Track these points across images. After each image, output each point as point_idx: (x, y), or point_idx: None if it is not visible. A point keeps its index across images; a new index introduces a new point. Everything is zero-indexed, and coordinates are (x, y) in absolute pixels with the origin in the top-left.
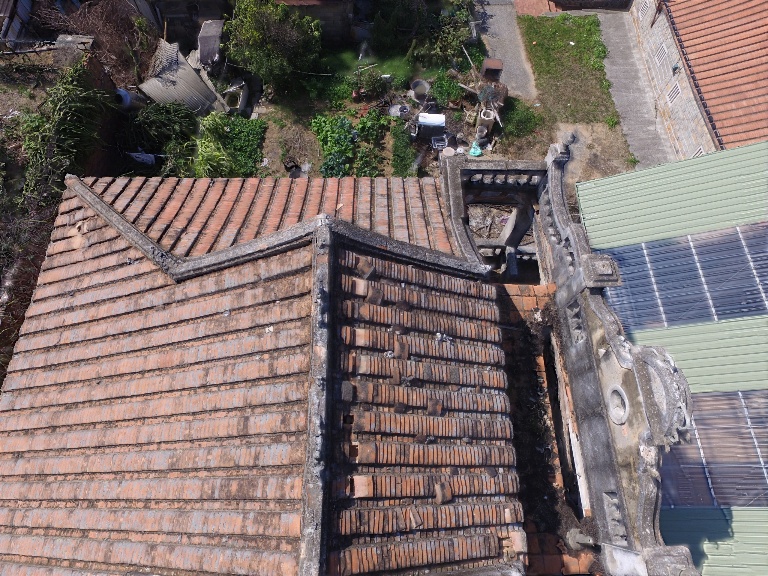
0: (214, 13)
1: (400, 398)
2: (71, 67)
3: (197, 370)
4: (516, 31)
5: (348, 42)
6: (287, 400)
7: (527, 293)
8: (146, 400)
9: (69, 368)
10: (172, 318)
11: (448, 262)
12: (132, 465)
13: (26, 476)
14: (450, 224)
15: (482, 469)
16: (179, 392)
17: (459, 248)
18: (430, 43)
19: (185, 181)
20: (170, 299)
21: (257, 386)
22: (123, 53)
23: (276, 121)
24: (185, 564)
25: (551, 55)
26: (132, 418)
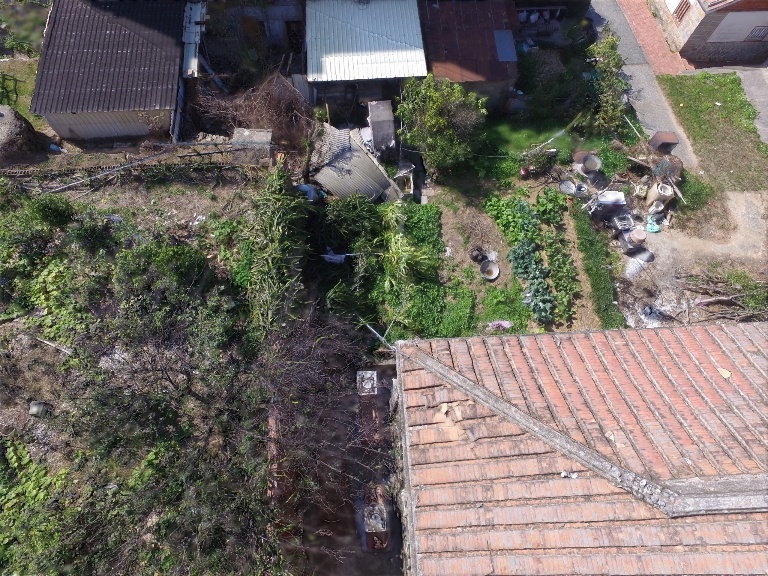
0: (375, 92)
1: None
2: (252, 164)
3: None
4: (659, 92)
5: (500, 113)
6: None
7: None
8: None
9: None
10: (690, 569)
11: None
12: None
13: None
14: None
15: None
16: None
17: None
18: None
19: (529, 342)
20: (673, 541)
21: None
22: (282, 138)
23: (448, 204)
24: None
25: (701, 117)
26: None
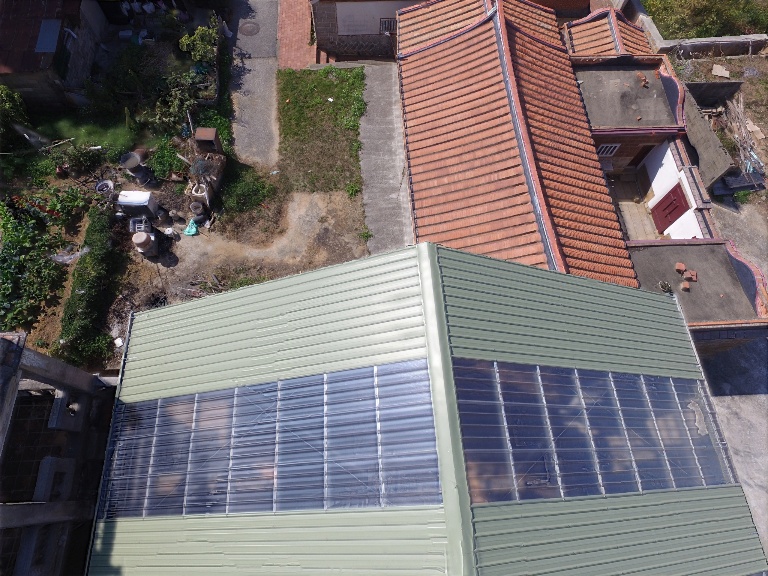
0: None
1: None
2: None
3: None
4: (272, 87)
5: (71, 108)
6: None
7: None
8: None
9: None
10: None
11: None
12: None
13: None
14: None
15: None
16: None
17: None
18: None
19: None
20: None
21: None
22: None
23: None
24: None
25: (304, 114)
26: None
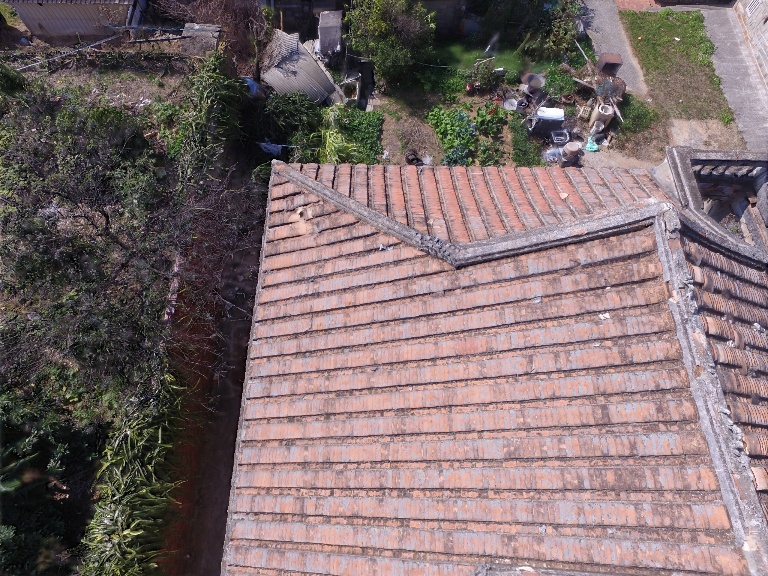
0: (329, 4)
1: (754, 389)
2: (199, 56)
3: (514, 357)
4: (619, 26)
5: (455, 35)
6: (657, 388)
7: None
8: (448, 388)
9: (331, 355)
10: (462, 304)
11: (745, 251)
12: (452, 454)
13: (304, 464)
14: (691, 214)
15: None
16: (492, 380)
17: (724, 238)
18: (540, 37)
19: (392, 168)
20: (453, 285)
21: (608, 374)
22: (238, 43)
23: (392, 113)
24: (566, 556)
25: (657, 51)
26: (435, 406)
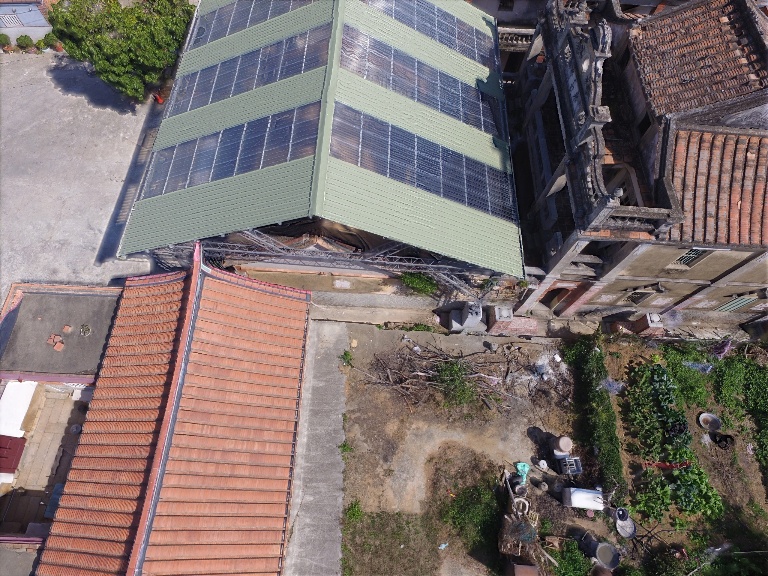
0: None
1: None
2: None
3: None
4: None
5: None
6: None
7: None
8: None
9: None
10: None
11: (696, 109)
12: None
13: None
14: None
15: None
16: None
17: None
18: None
19: None
20: None
21: None
22: None
23: (761, 511)
24: None
25: None
26: None
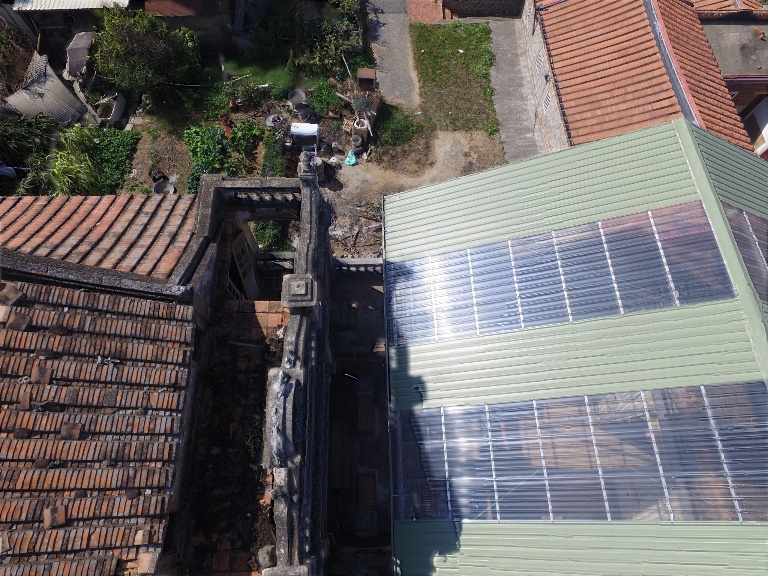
0: (89, 25)
1: (23, 423)
2: None
3: None
4: (407, 39)
5: (233, 52)
6: None
7: (275, 310)
8: None
9: None
10: None
11: (132, 285)
12: None
13: None
14: None
15: (123, 491)
16: None
17: None
18: (312, 52)
19: None
20: None
21: None
22: None
23: (150, 132)
24: None
25: (438, 63)
26: None
